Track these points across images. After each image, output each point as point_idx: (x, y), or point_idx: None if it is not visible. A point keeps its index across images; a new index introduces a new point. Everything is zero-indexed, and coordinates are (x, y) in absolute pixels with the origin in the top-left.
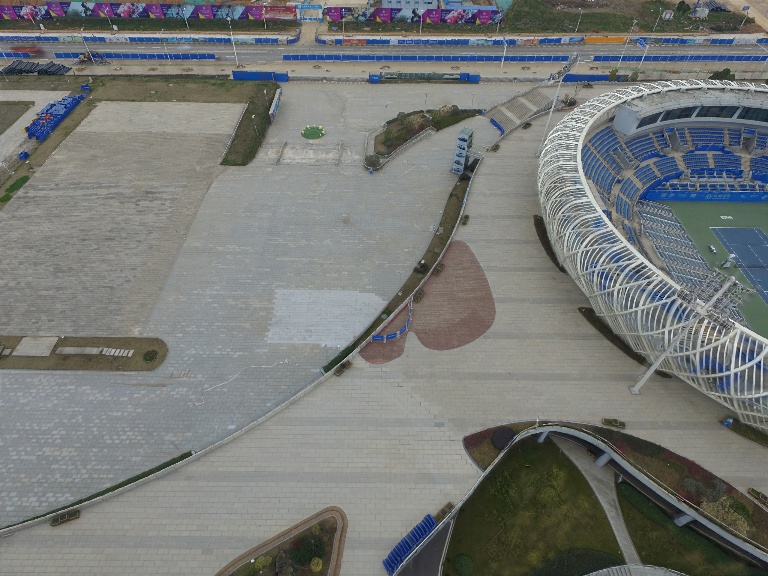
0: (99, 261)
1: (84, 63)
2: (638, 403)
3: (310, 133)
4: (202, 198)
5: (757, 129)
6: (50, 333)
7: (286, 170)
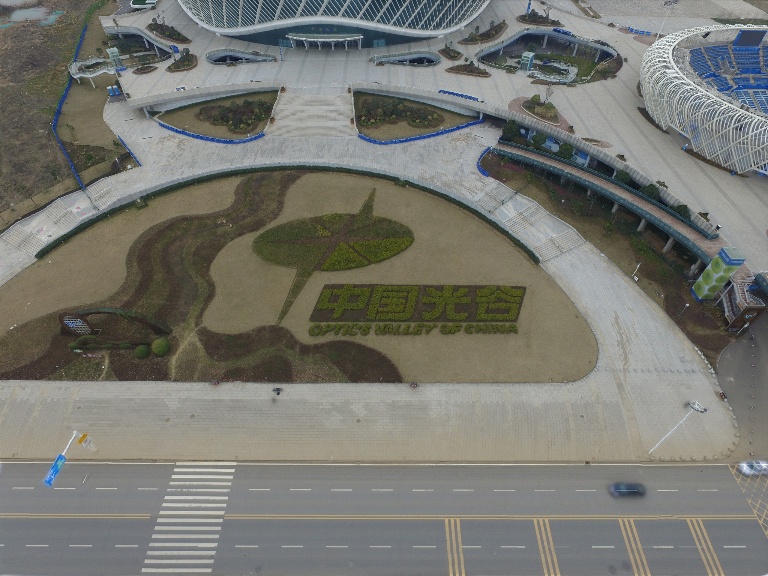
0: (626, 6)
1: None
2: None
3: None
4: None
5: None
6: (591, 5)
7: None
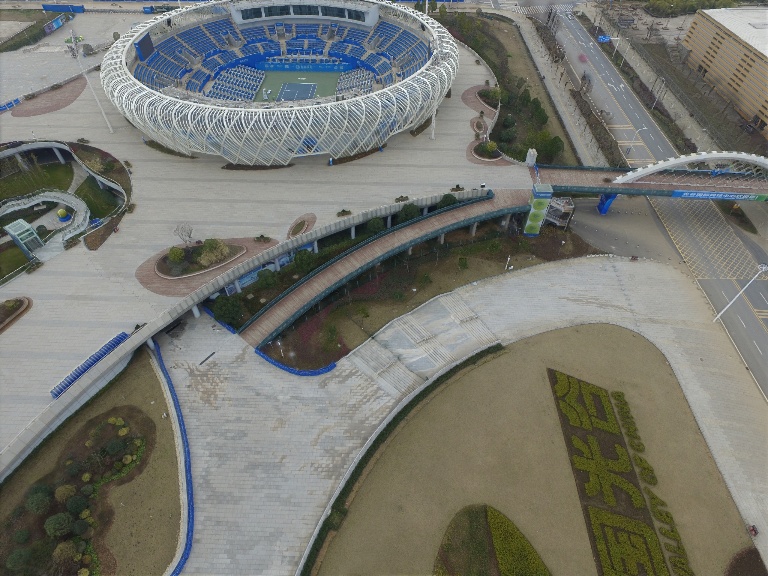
0: None
1: None
2: (108, 136)
3: None
4: None
5: (339, 24)
6: None
7: (28, 55)
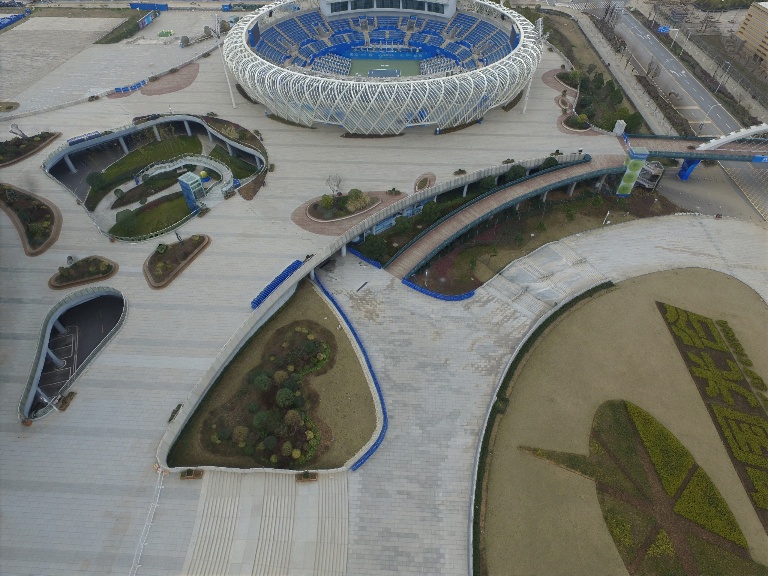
0: None
1: (36, 2)
2: (232, 110)
3: (163, 34)
4: (72, 56)
5: (418, 16)
6: None
7: (131, 46)
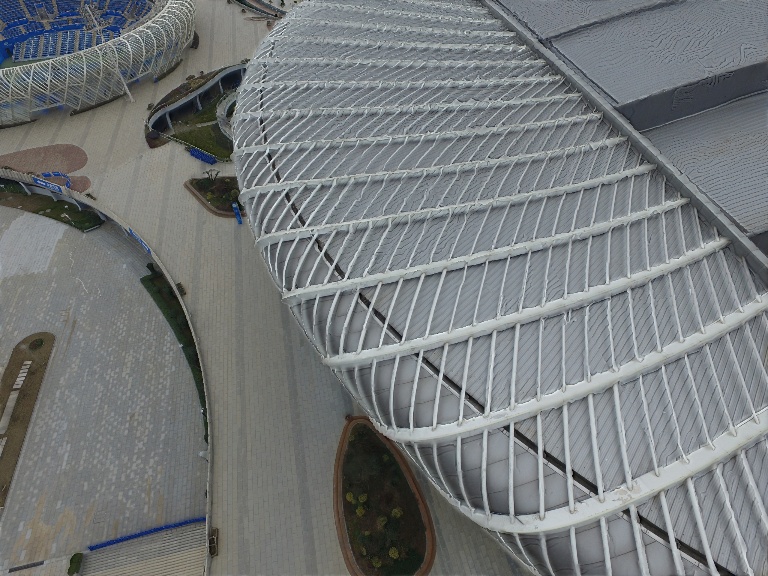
0: None
1: None
2: (141, 101)
3: None
4: None
5: None
6: None
7: None
